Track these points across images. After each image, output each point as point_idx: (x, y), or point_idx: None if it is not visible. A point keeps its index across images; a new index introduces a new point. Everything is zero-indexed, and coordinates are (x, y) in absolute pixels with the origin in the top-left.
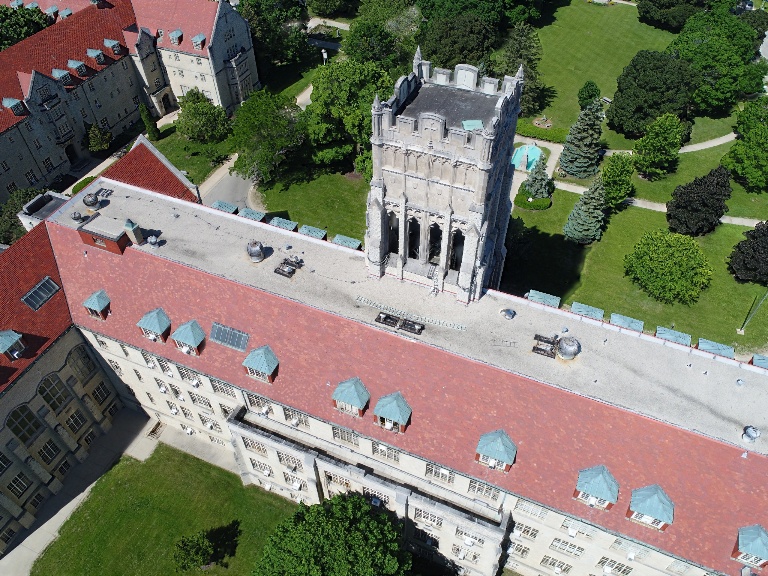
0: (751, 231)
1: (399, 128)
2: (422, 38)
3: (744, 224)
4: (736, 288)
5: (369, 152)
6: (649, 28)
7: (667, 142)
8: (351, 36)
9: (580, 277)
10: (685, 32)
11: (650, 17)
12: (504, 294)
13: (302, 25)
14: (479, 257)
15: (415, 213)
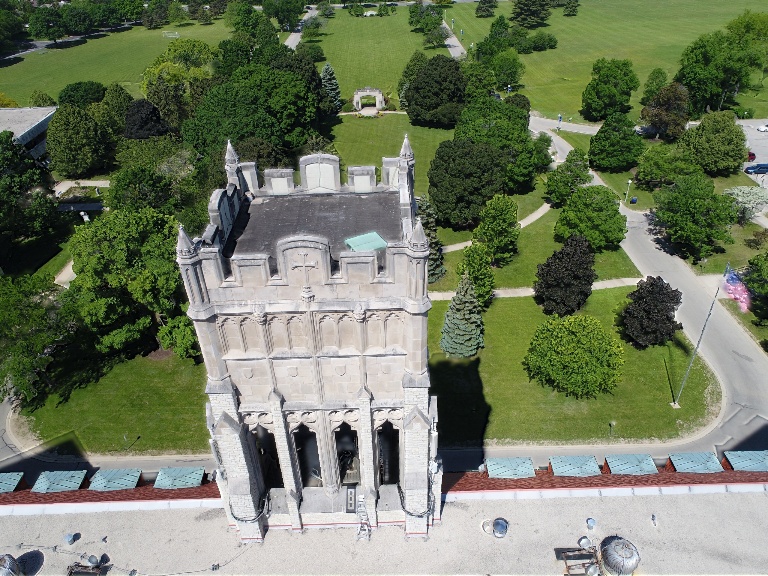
0: (635, 292)
1: (240, 279)
2: (202, 176)
3: (607, 287)
4: (641, 357)
5: (174, 319)
6: (424, 129)
7: (506, 223)
8: (114, 188)
9: (485, 398)
10: (465, 123)
11: (422, 119)
12: (473, 493)
13: (46, 189)
14: (432, 456)
15: (302, 417)
